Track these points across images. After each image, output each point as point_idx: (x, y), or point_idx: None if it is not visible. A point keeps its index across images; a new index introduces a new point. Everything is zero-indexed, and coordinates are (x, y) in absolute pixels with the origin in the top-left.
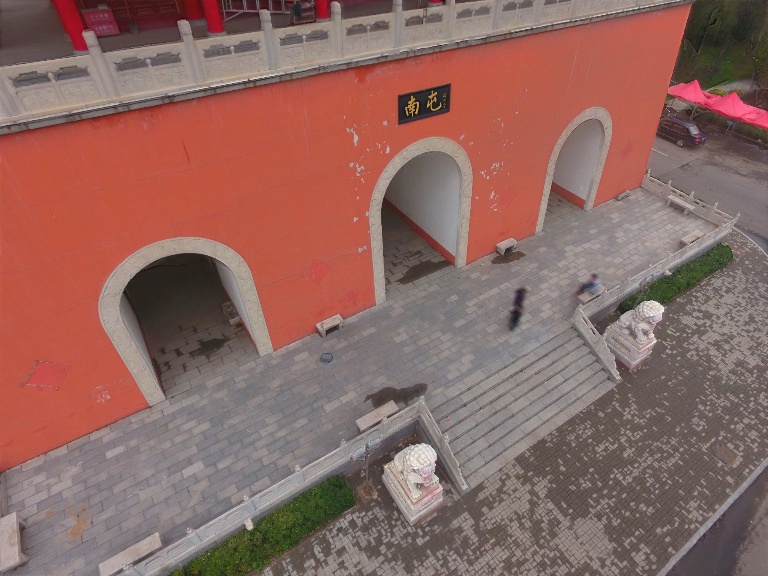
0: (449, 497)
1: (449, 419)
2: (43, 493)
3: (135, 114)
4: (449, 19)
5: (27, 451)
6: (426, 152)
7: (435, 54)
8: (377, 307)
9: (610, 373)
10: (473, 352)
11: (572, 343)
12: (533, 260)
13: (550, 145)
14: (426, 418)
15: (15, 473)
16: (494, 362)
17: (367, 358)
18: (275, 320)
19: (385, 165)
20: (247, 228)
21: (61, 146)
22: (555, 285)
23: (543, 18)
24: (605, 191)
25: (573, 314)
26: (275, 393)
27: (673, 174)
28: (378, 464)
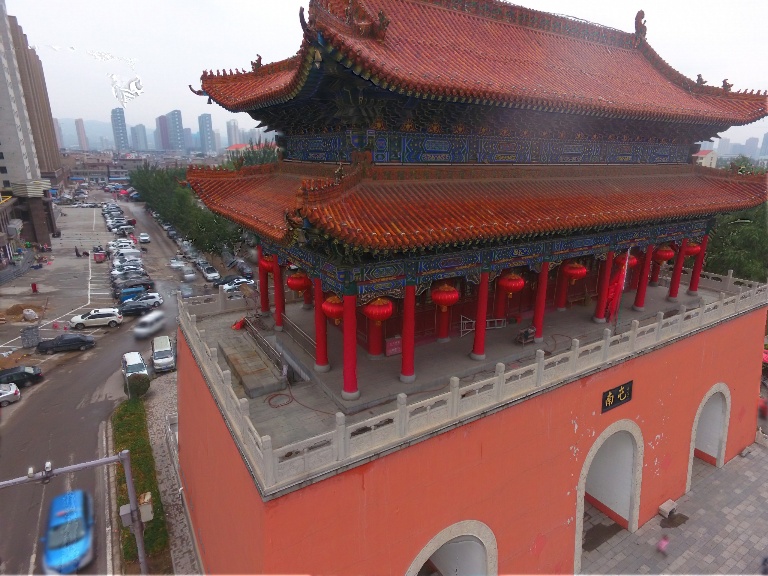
0: None
1: None
2: None
3: (462, 427)
4: (633, 339)
5: None
6: (616, 432)
7: (625, 362)
8: None
9: None
10: None
11: None
12: (699, 524)
13: (691, 416)
14: None
15: None
16: None
17: None
18: None
19: (591, 445)
20: (502, 508)
21: (419, 455)
22: (736, 554)
23: (683, 329)
24: (730, 449)
25: None
26: None
27: None
28: None
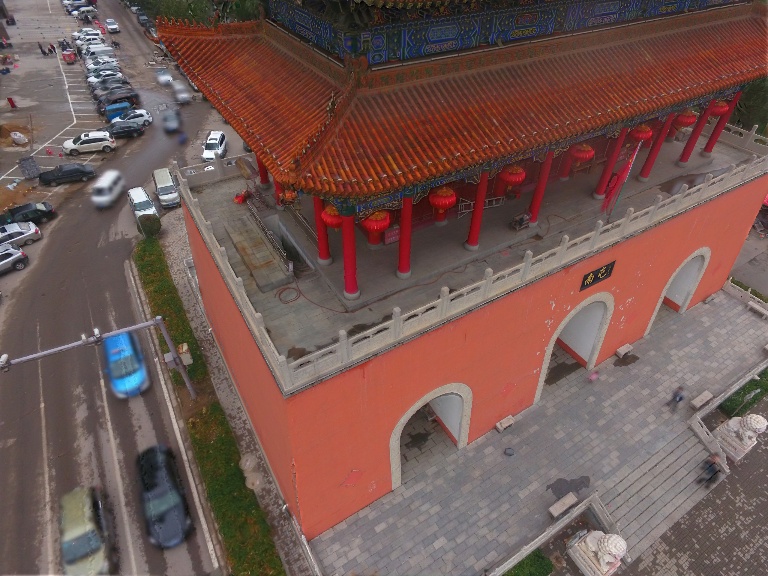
0: (618, 567)
1: (610, 506)
2: (343, 558)
3: (450, 323)
4: (625, 225)
5: (324, 526)
6: (590, 303)
7: (612, 247)
8: (534, 406)
9: (721, 467)
10: (617, 449)
11: (690, 441)
12: (646, 363)
13: (666, 278)
14: (598, 507)
15: (318, 542)
16: (635, 458)
17: (538, 453)
18: (474, 425)
19: (564, 317)
20: (479, 372)
21: (411, 348)
22: (669, 388)
23: (680, 206)
24: (696, 297)
25: (690, 418)
26: (479, 481)
27: (744, 269)
28: (560, 539)
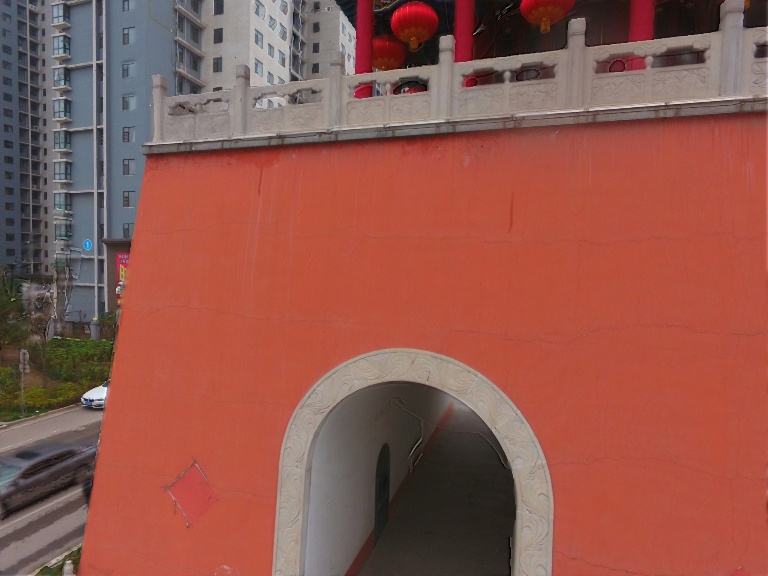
0: None
1: None
2: None
3: (460, 142)
4: None
5: None
6: None
7: None
8: None
9: None
10: None
11: None
12: None
13: None
14: None
15: None
16: None
17: None
18: None
19: None
20: (577, 395)
21: (359, 170)
22: None
23: None
24: None
25: None
26: None
27: None
28: None
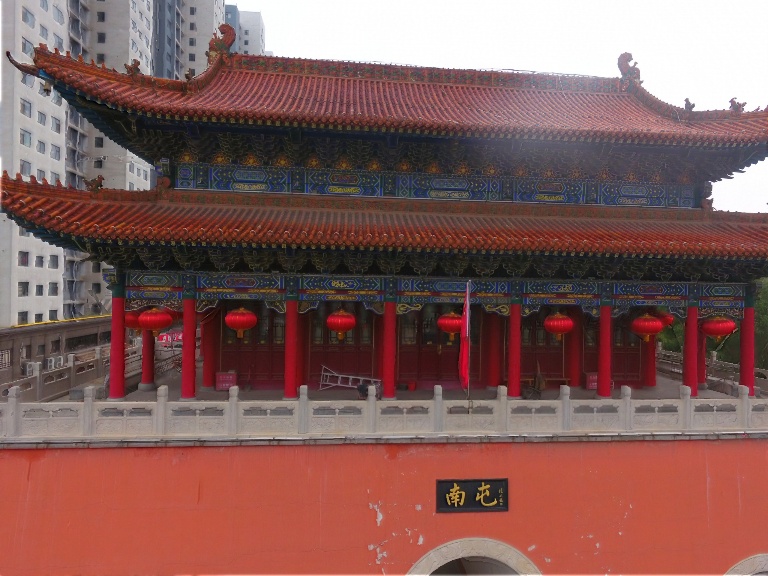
0: None
1: None
2: None
3: (170, 450)
4: (500, 413)
5: None
6: (476, 556)
7: (484, 444)
8: None
9: None
10: None
11: None
12: None
13: None
14: None
15: None
16: None
17: None
18: None
19: (416, 559)
20: None
21: (105, 465)
22: None
23: (638, 426)
24: None
25: None
26: None
27: None
28: None
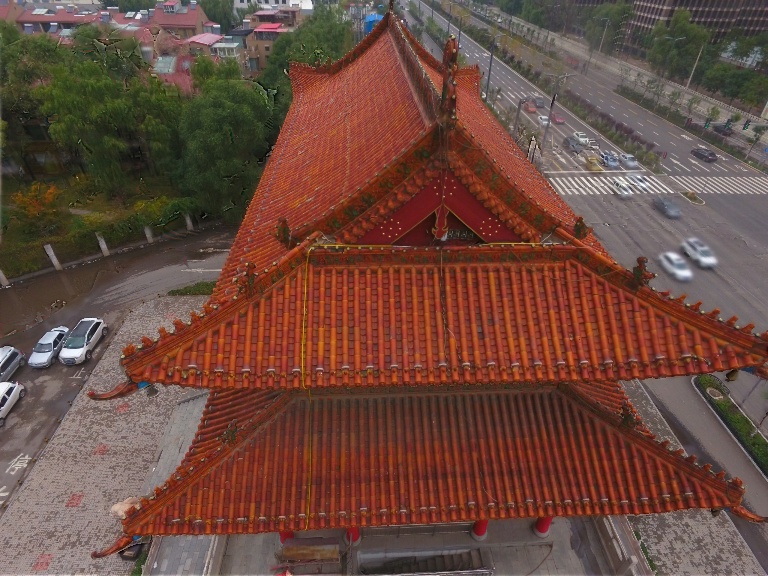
0: None
1: None
2: None
3: None
4: None
5: None
6: None
7: None
8: None
9: None
10: None
11: None
12: None
13: None
14: None
15: None
16: None
17: None
18: None
19: None
20: None
21: None
22: None
23: None
24: None
25: None
26: None
27: None
28: None
